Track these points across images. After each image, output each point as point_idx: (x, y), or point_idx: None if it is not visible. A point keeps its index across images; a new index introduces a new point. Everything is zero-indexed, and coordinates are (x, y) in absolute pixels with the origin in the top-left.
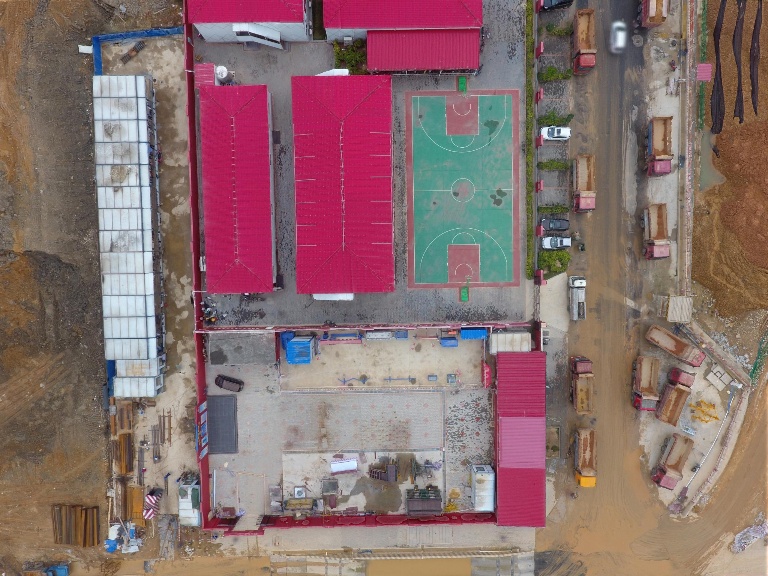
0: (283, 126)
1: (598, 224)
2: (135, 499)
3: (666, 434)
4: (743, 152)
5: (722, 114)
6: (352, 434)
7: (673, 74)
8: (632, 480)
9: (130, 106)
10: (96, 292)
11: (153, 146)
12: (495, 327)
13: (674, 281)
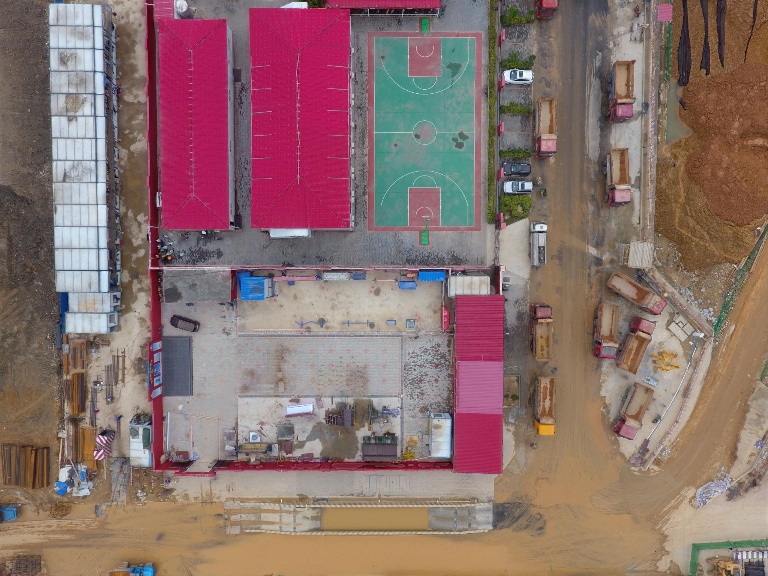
0: (244, 64)
1: (561, 170)
2: (87, 440)
3: (627, 385)
4: (709, 104)
5: (689, 66)
6: (309, 378)
7: (637, 20)
8: (593, 431)
9: (86, 35)
10: (52, 228)
11: (110, 78)
12: (454, 269)
13: (637, 229)
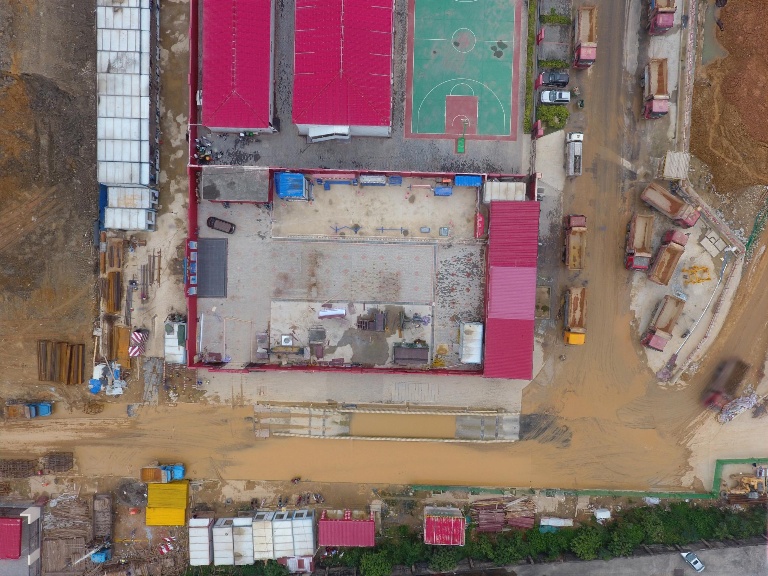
0: None
1: (598, 82)
2: (121, 339)
3: (657, 299)
4: (747, 23)
5: None
6: (342, 284)
7: None
8: (621, 345)
9: None
10: (92, 126)
11: None
12: (490, 175)
13: (672, 144)
